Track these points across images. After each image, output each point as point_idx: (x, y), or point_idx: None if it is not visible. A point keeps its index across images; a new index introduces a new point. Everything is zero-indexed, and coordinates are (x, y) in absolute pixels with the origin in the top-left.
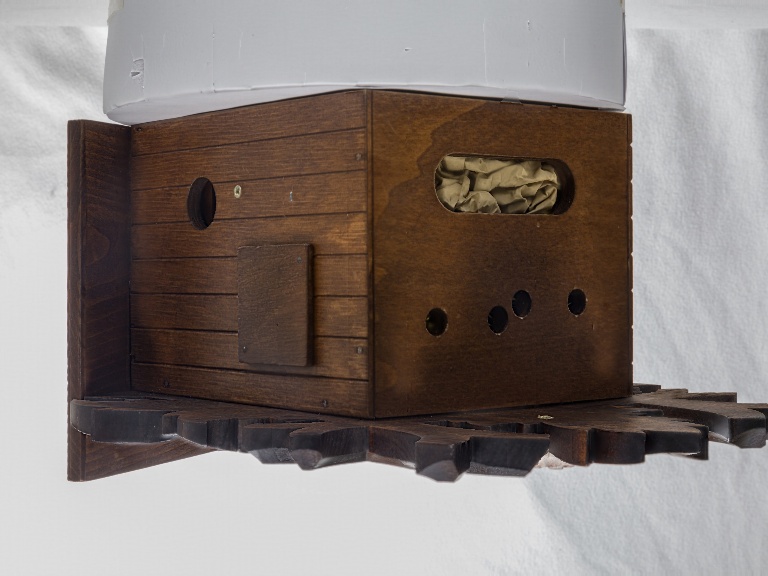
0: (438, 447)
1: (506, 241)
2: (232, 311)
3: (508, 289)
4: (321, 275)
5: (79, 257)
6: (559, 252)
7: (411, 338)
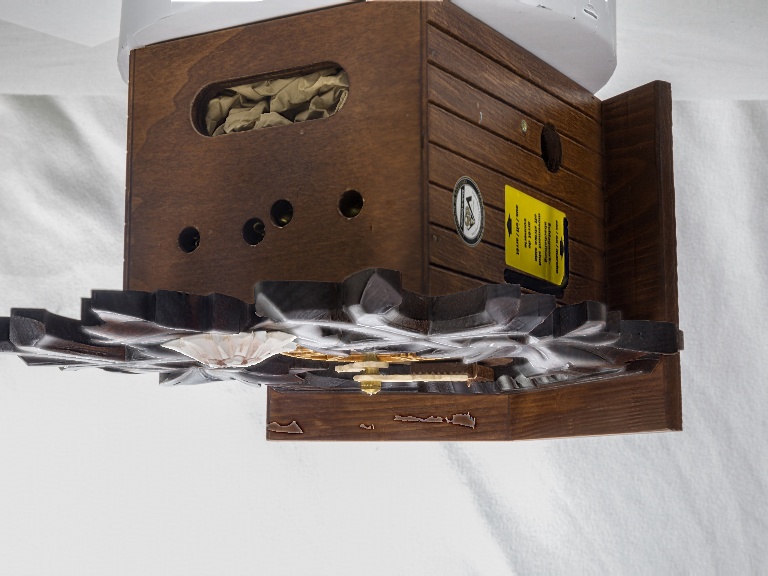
0: None
1: (264, 154)
2: None
3: (266, 200)
4: None
5: None
6: (328, 155)
7: (163, 256)
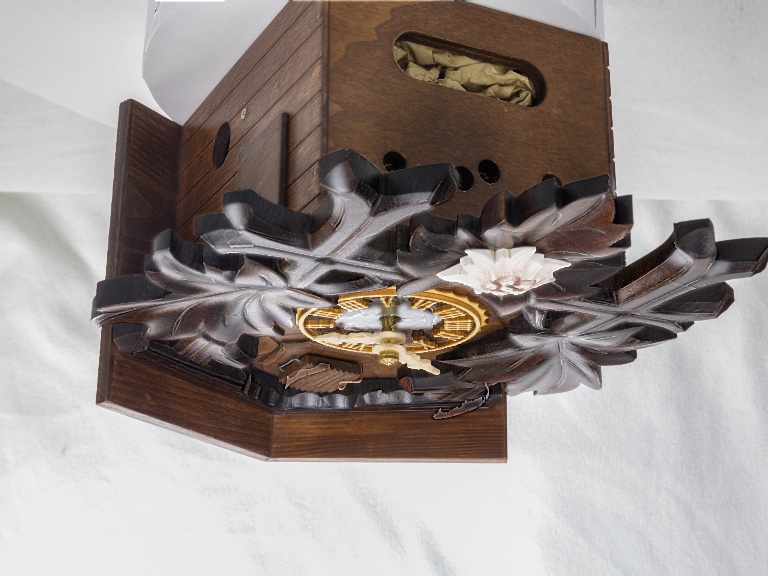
0: (336, 153)
1: (471, 115)
2: None
3: (473, 155)
4: (293, 133)
5: (119, 208)
6: (530, 138)
7: None
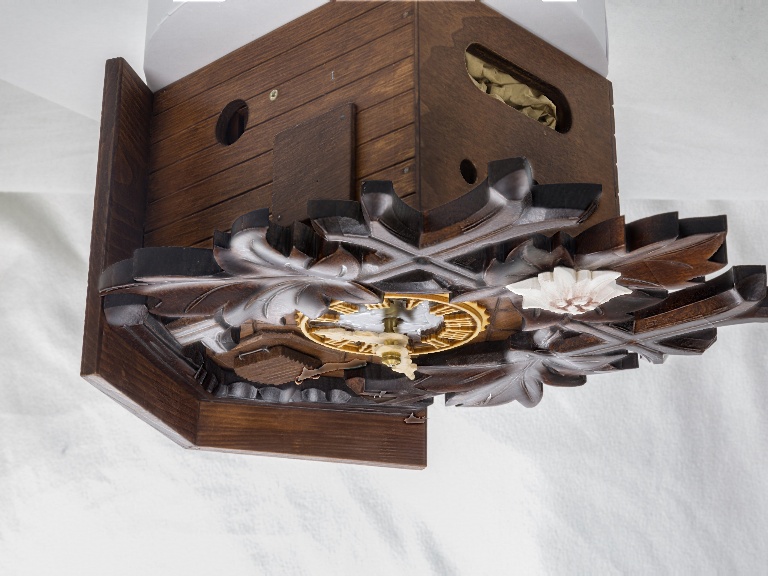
0: (511, 160)
1: (521, 133)
2: (263, 198)
3: None
4: (364, 126)
5: (109, 171)
6: (562, 163)
7: (449, 174)
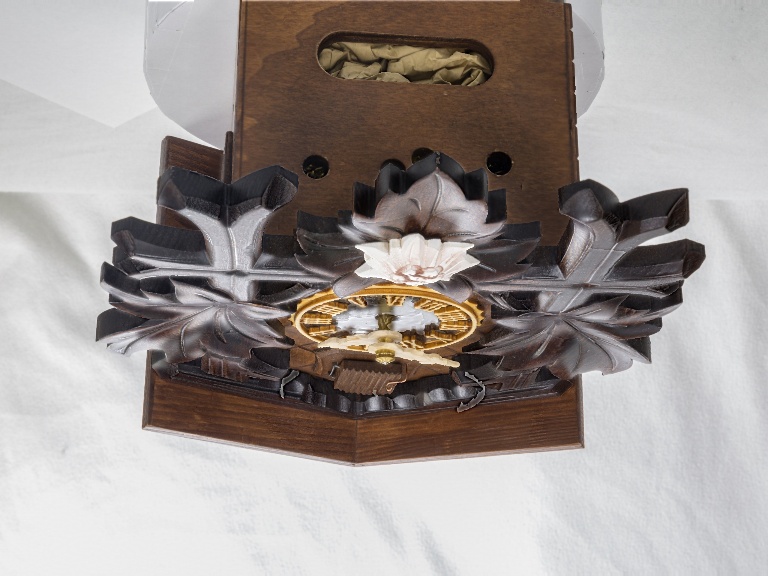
0: (165, 173)
1: (404, 105)
2: None
3: (406, 145)
4: None
5: None
6: (474, 118)
7: None
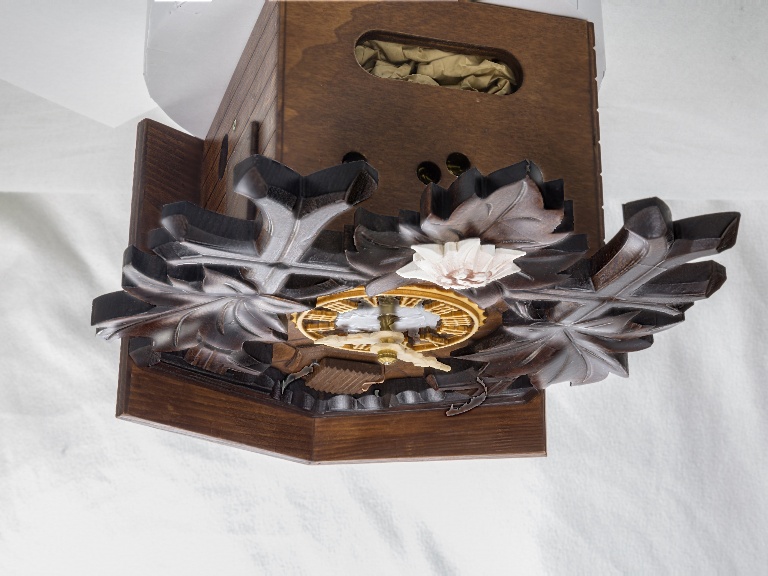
0: (246, 160)
1: (439, 108)
2: None
3: (441, 149)
4: (260, 141)
5: (136, 225)
6: (504, 127)
7: None
